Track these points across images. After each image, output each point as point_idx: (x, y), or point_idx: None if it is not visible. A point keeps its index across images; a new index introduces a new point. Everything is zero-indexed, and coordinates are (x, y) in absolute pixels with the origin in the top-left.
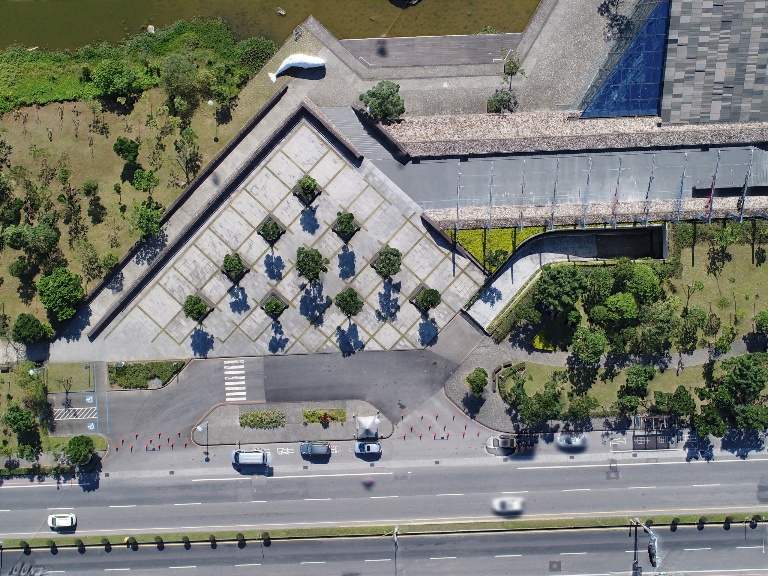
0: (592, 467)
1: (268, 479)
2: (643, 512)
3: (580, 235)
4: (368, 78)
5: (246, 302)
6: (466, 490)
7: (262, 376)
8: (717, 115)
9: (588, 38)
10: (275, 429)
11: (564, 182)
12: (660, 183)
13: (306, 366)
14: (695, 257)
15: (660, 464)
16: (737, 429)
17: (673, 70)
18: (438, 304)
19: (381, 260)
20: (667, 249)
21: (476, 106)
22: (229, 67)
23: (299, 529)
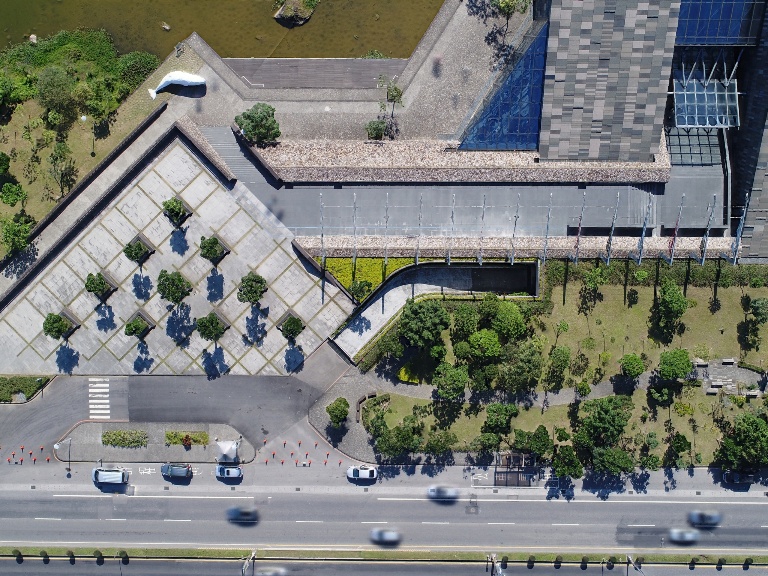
0: (452, 501)
1: (129, 498)
2: (501, 548)
3: (455, 267)
4: (249, 98)
5: (113, 321)
6: (325, 518)
7: (126, 395)
8: (596, 153)
9: (474, 67)
10: (137, 449)
11: (438, 214)
12: (535, 219)
13: (171, 387)
14: (566, 296)
15: (520, 501)
16: (599, 470)
17: (550, 106)
18: (299, 333)
19: (242, 287)
20: (538, 286)
21: (357, 132)
22: (108, 81)
23: (157, 549)
